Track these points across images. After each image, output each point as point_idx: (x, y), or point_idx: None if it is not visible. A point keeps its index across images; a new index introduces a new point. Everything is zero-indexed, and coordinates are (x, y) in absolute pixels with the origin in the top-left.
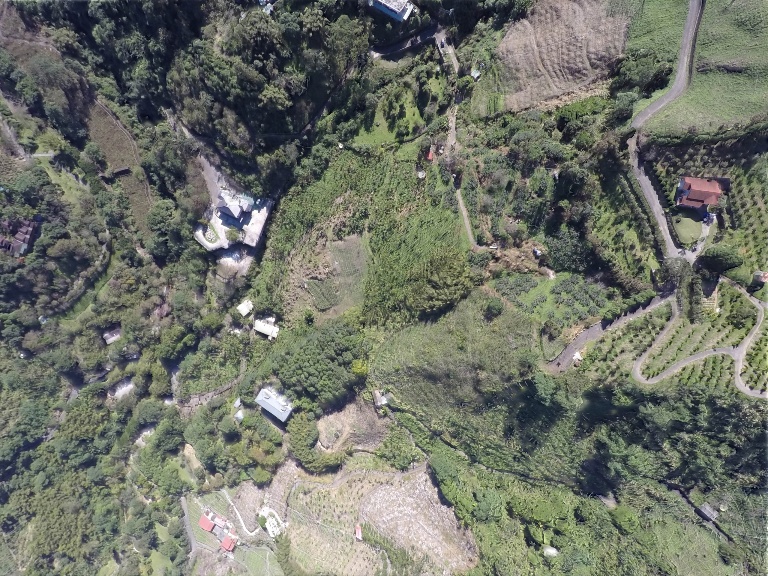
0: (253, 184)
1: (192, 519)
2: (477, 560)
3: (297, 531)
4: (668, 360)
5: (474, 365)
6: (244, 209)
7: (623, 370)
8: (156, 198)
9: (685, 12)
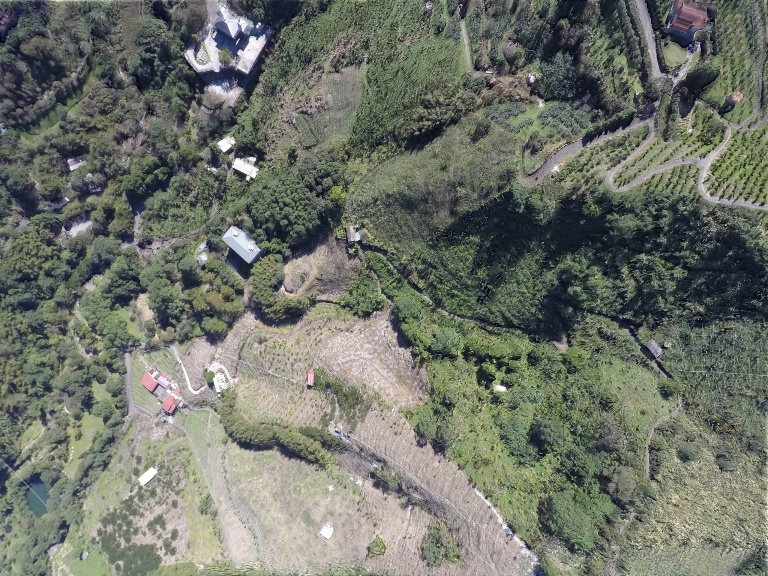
0: (256, 4)
1: (134, 378)
2: (427, 398)
3: (246, 385)
4: (640, 168)
5: (454, 184)
6: (243, 29)
7: (597, 178)
8: (149, 16)
9: None
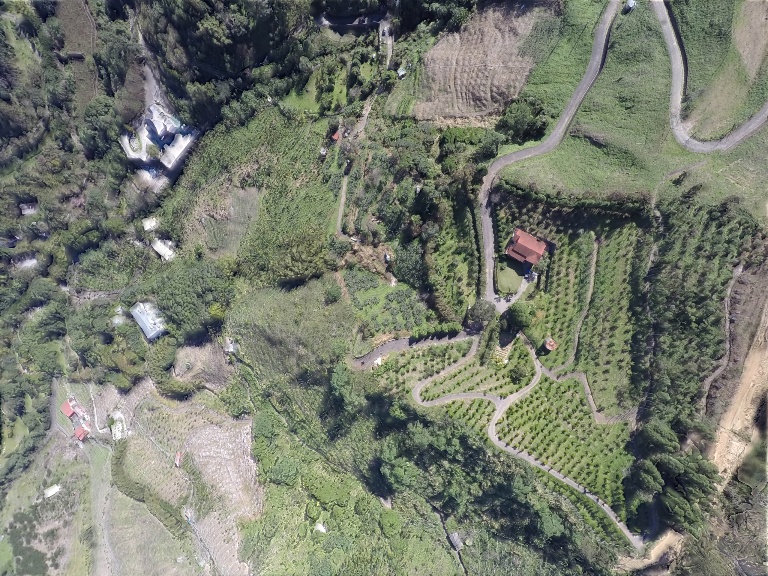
0: (182, 107)
1: (57, 400)
2: (259, 516)
3: (134, 441)
4: (444, 390)
5: (300, 340)
6: (168, 128)
7: (407, 386)
8: (100, 91)
9: (581, 75)
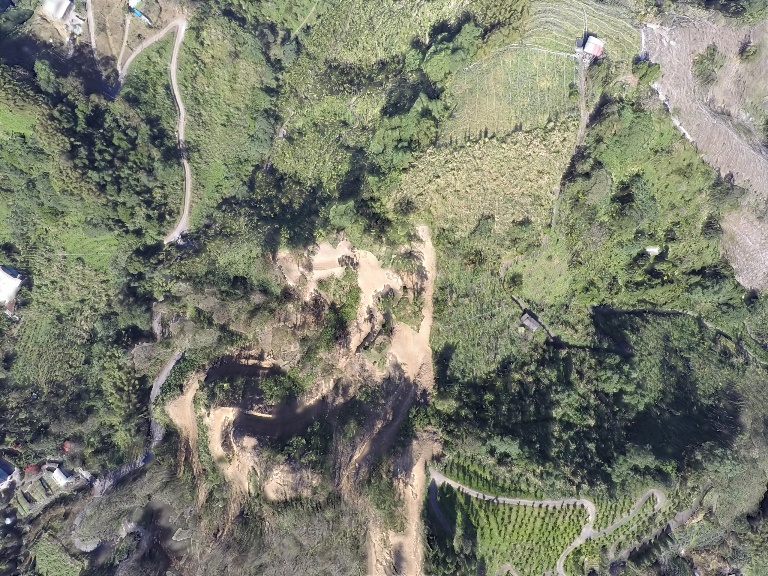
0: None
1: None
2: None
3: None
4: None
5: (757, 459)
6: None
7: None
8: None
9: None
